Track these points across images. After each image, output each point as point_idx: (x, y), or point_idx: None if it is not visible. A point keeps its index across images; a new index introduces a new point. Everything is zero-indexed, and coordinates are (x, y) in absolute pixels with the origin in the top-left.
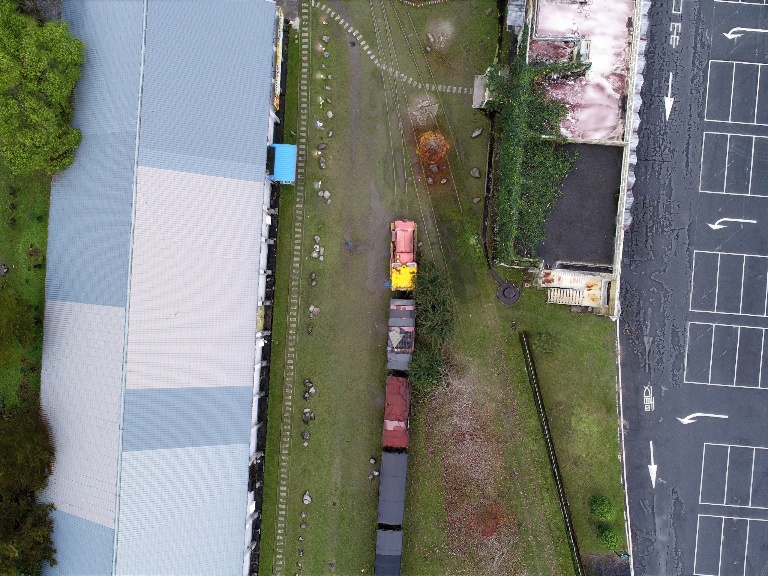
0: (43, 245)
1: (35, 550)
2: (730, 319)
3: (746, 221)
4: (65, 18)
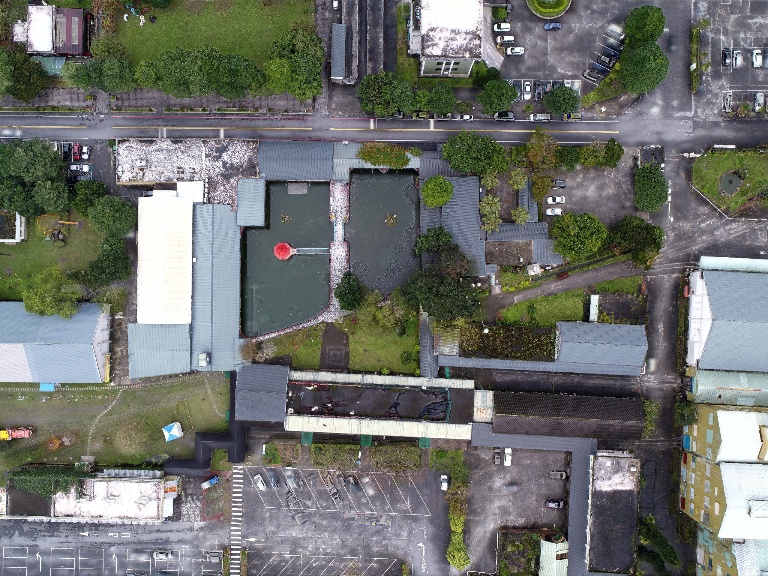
0: (20, 288)
1: None
2: (1, 563)
3: (41, 567)
4: (91, 305)
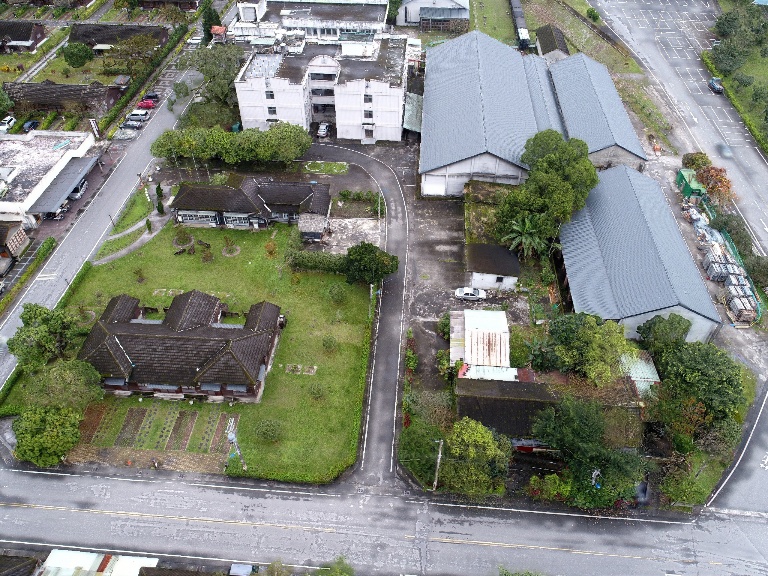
0: None
1: None
2: None
3: None
4: None
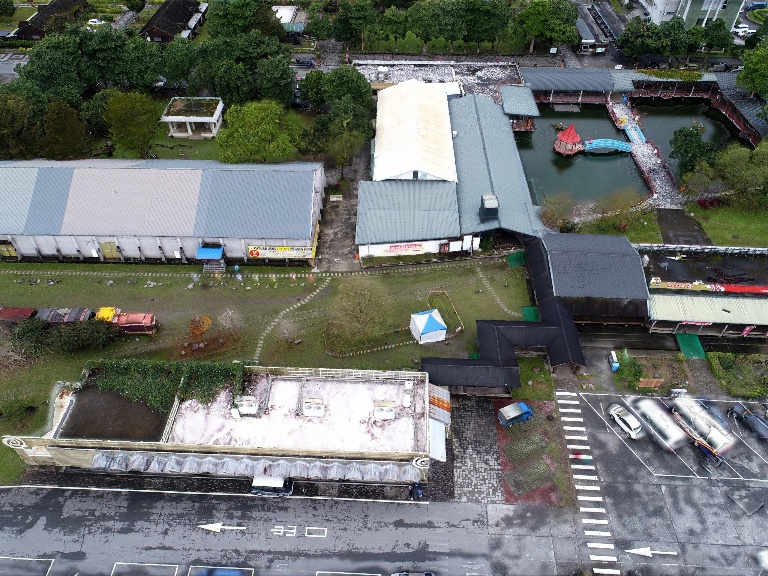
0: None
1: (6, 151)
2: None
3: None
4: None
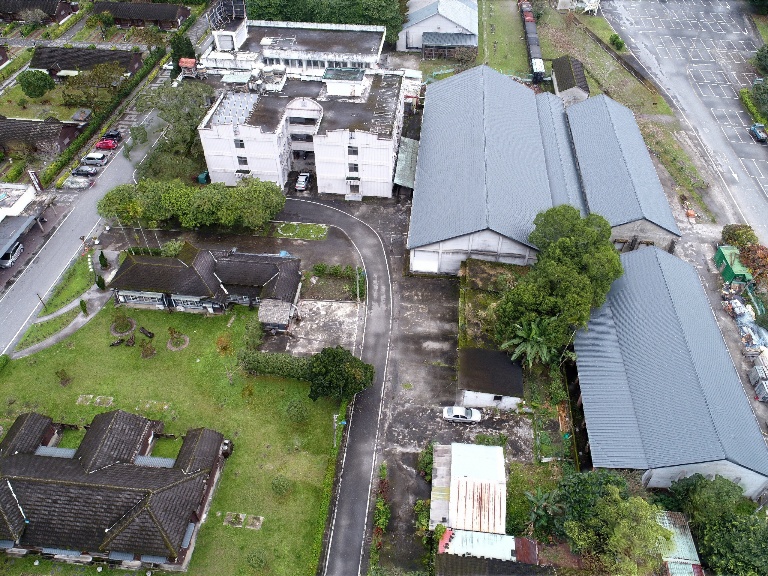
0: None
1: None
2: None
3: (643, 5)
4: None
